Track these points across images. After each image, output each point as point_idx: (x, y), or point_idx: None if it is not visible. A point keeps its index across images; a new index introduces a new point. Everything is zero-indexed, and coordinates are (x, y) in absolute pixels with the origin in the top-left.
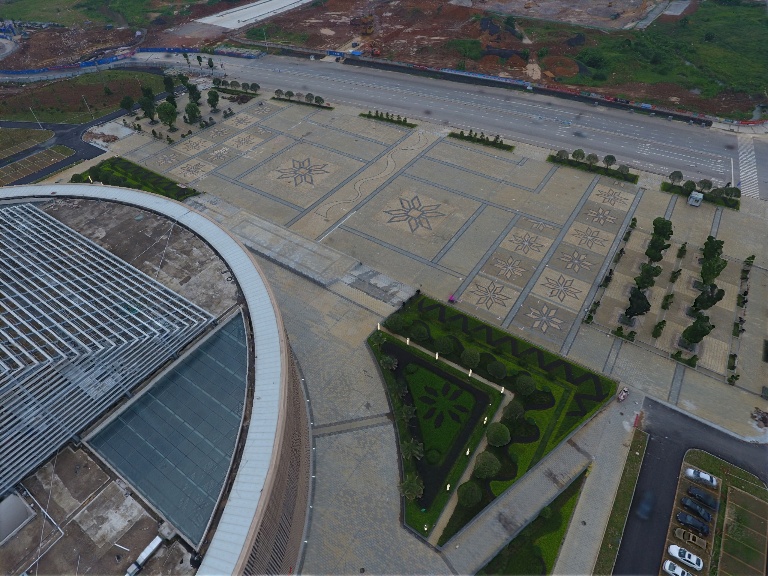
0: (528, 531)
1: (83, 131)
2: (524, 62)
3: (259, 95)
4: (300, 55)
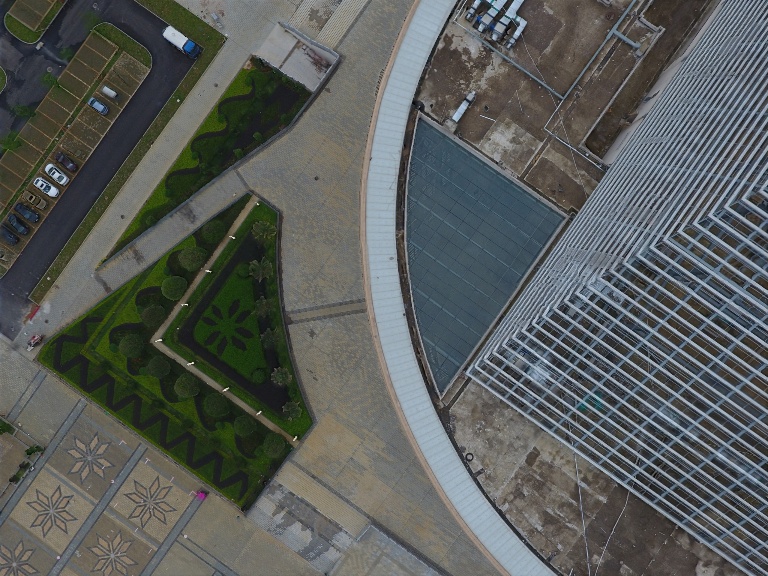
0: None
1: None
2: None
3: None
4: None
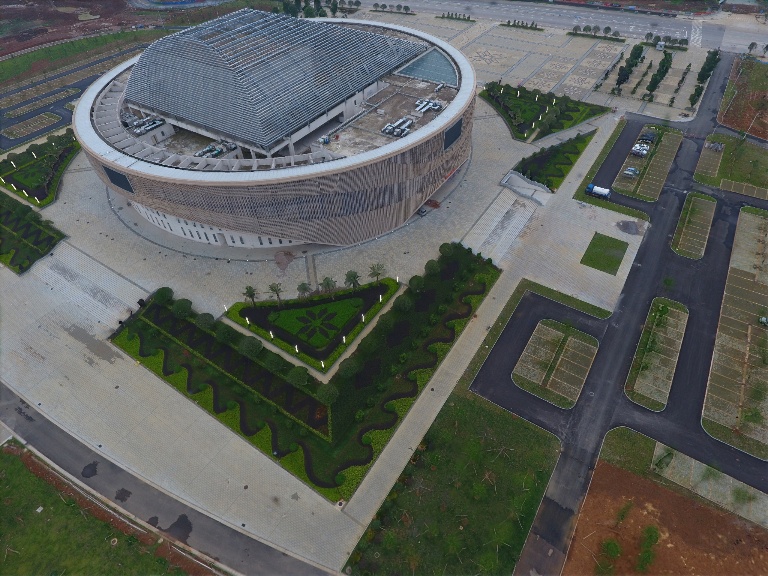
0: None
1: None
2: None
3: (360, 9)
4: None
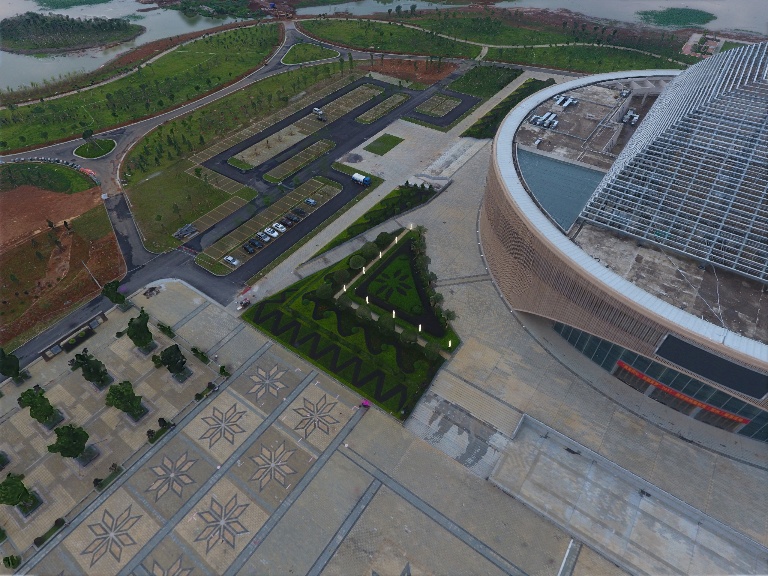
0: (353, 233)
1: None
2: None
3: None
4: None
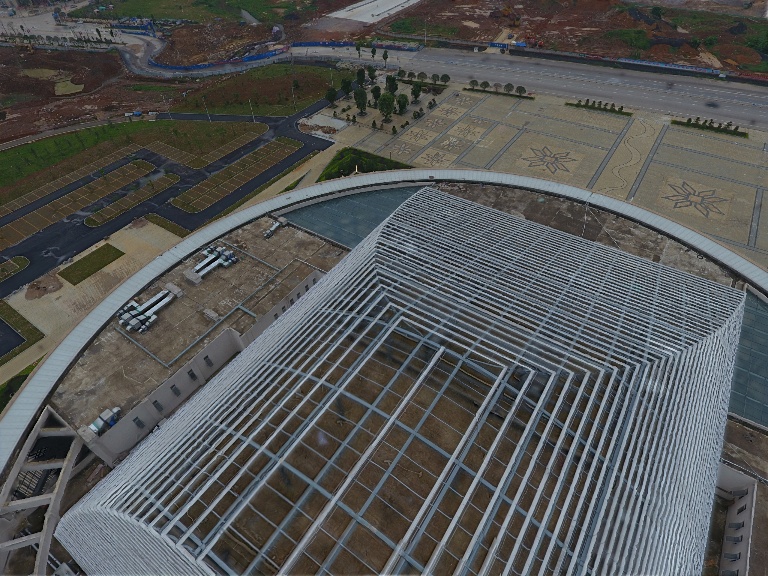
0: None
1: (295, 123)
2: (696, 51)
3: (448, 86)
4: (460, 47)
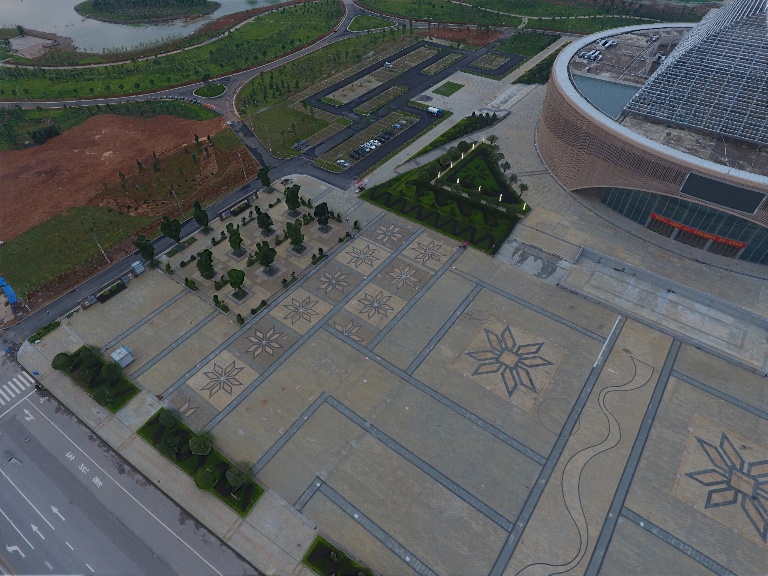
0: (437, 145)
1: None
2: None
3: None
4: None
